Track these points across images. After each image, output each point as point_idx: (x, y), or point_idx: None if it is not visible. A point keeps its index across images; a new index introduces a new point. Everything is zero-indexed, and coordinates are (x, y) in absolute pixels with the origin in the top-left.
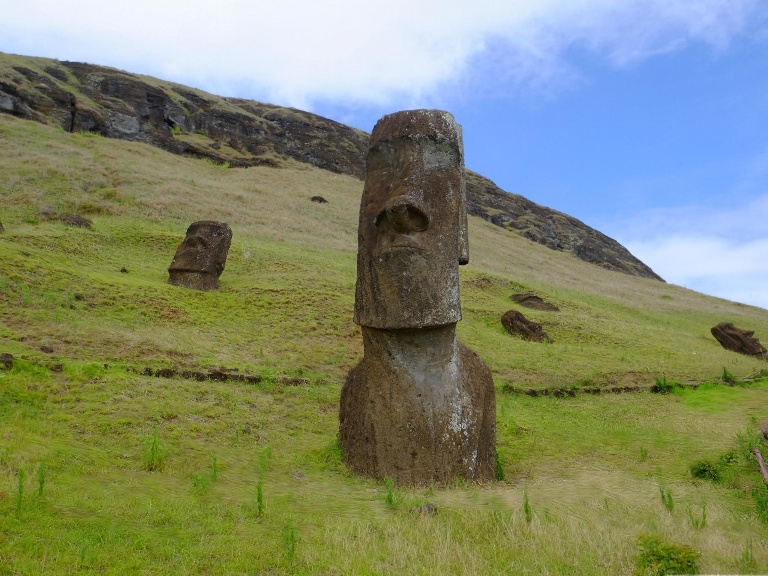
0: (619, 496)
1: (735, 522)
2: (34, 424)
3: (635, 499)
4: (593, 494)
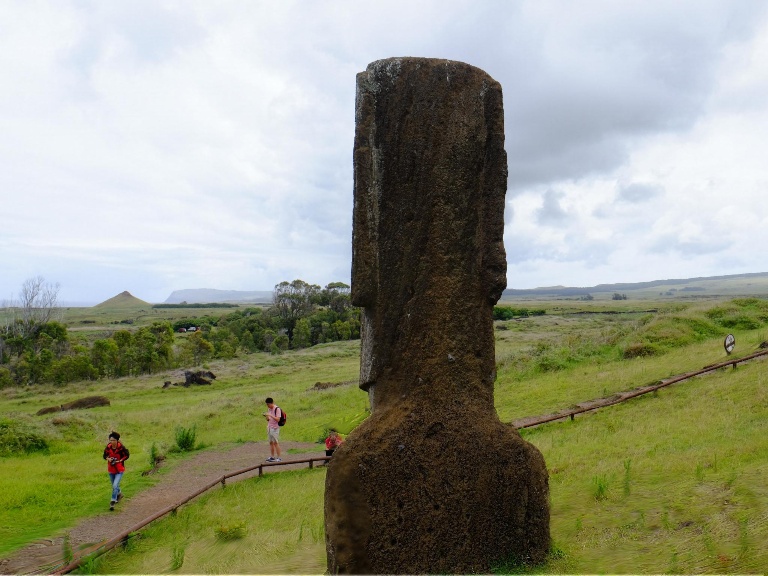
0: (210, 573)
1: (141, 569)
2: (757, 468)
3: (200, 570)
4: (234, 570)
